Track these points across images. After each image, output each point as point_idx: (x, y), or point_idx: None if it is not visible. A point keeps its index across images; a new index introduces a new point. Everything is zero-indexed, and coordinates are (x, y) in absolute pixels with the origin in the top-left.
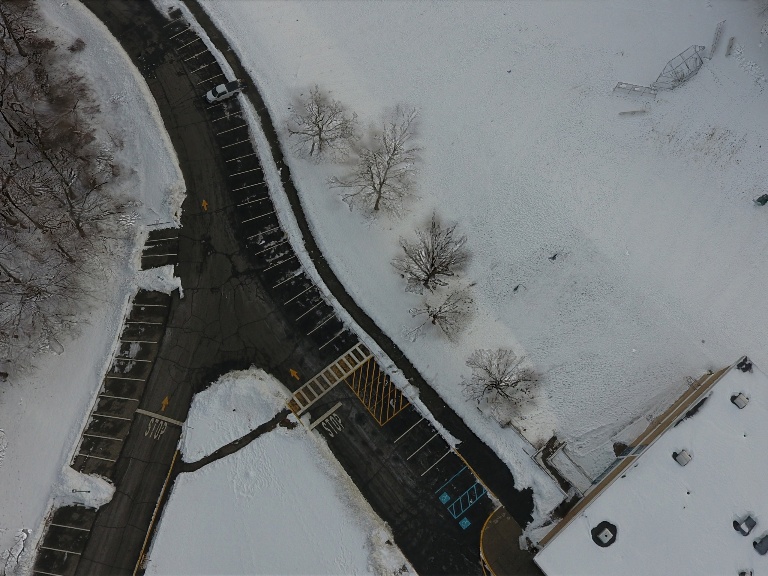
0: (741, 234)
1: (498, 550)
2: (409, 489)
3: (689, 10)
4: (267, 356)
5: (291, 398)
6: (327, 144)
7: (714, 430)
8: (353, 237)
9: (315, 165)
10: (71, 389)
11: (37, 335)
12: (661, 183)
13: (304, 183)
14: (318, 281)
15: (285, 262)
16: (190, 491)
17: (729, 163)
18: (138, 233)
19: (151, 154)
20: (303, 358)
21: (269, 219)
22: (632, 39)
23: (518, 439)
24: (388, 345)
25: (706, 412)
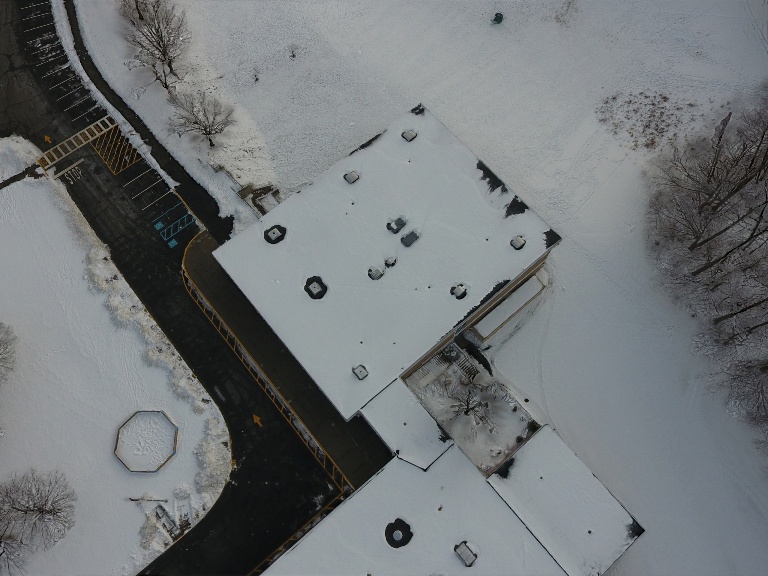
0: (473, 44)
1: (197, 262)
2: (130, 220)
3: None
4: (27, 127)
5: (42, 156)
6: None
7: (383, 157)
8: (116, 38)
9: None
10: None
11: None
12: (408, 6)
13: (82, 1)
14: (80, 71)
15: (56, 59)
16: None
17: None
18: None
19: None
20: (57, 128)
21: (48, 28)
22: None
23: (228, 180)
24: (131, 116)
25: (378, 144)
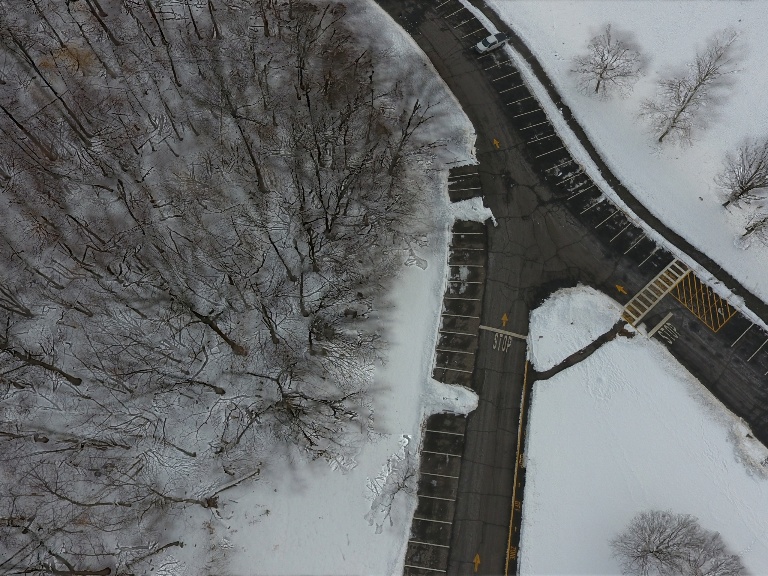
0: None
1: None
2: (756, 387)
3: None
4: (591, 274)
5: (623, 310)
6: (612, 82)
7: None
8: (646, 166)
9: None
10: (416, 309)
11: (379, 260)
12: None
13: (587, 120)
14: (623, 206)
15: (586, 191)
16: (549, 397)
17: None
18: None
19: (434, 101)
20: (625, 275)
21: (561, 153)
22: None
23: None
24: (704, 260)
25: None
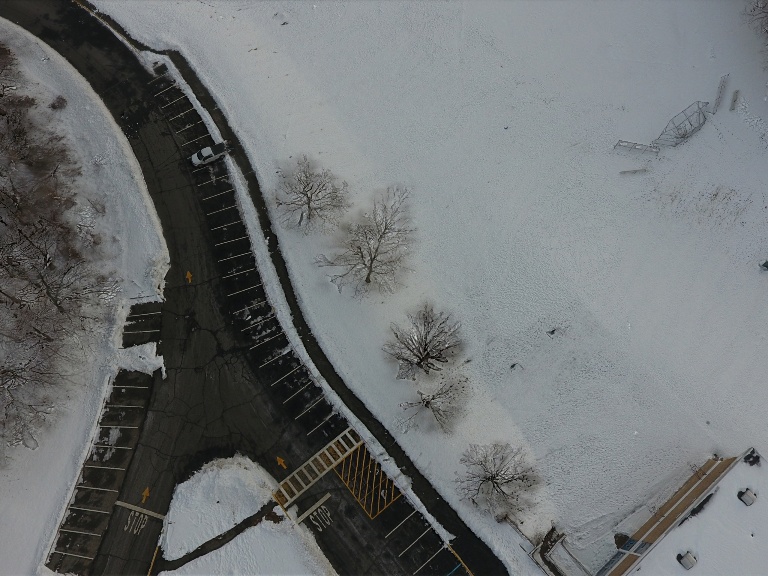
0: (746, 302)
1: None
2: None
3: (692, 61)
4: (253, 442)
5: (278, 489)
6: (316, 214)
7: (720, 529)
8: (343, 312)
9: None
10: (47, 480)
11: (12, 423)
12: (663, 247)
13: (292, 253)
14: (306, 360)
15: (272, 339)
16: None
17: (734, 225)
18: (119, 308)
19: (134, 221)
20: (290, 445)
21: (256, 292)
22: (633, 93)
23: (515, 534)
24: (379, 431)
25: (712, 510)
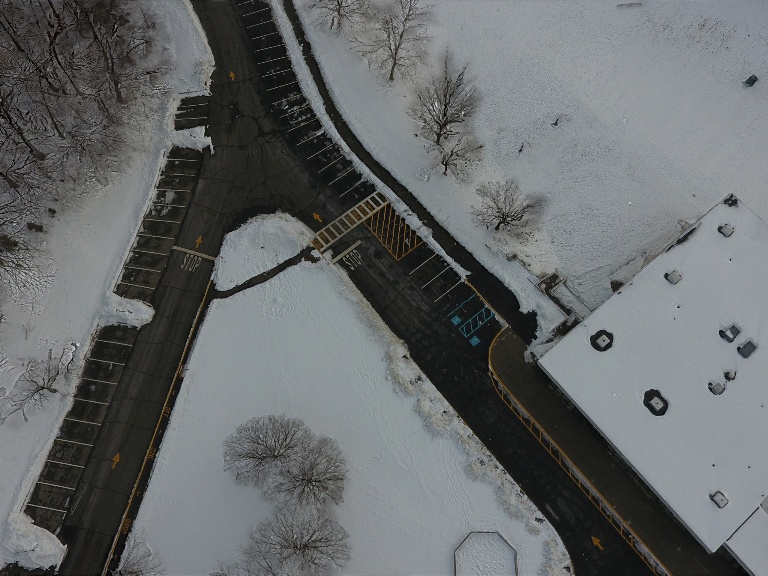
0: (730, 110)
1: (505, 363)
2: (423, 313)
3: None
4: (292, 202)
5: (314, 237)
6: (346, 18)
7: (702, 255)
8: (370, 102)
9: (335, 37)
10: (113, 228)
11: (81, 180)
12: (656, 66)
13: (324, 57)
14: (338, 139)
15: (307, 124)
16: (223, 314)
17: (720, 50)
18: (171, 99)
19: (182, 33)
20: (325, 204)
21: (292, 88)
22: None
23: (523, 270)
24: (403, 193)
25: (695, 240)
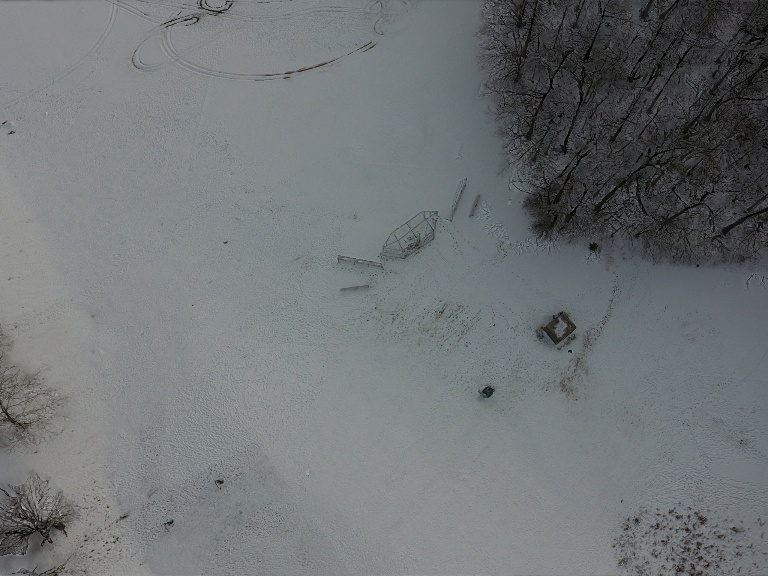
0: (455, 436)
1: None
2: None
3: (436, 163)
4: None
5: None
6: None
7: None
8: None
9: None
10: None
11: None
12: (374, 374)
13: None
14: None
15: None
16: None
17: (457, 346)
18: None
19: None
20: None
21: None
22: (368, 199)
23: None
24: None
25: None
